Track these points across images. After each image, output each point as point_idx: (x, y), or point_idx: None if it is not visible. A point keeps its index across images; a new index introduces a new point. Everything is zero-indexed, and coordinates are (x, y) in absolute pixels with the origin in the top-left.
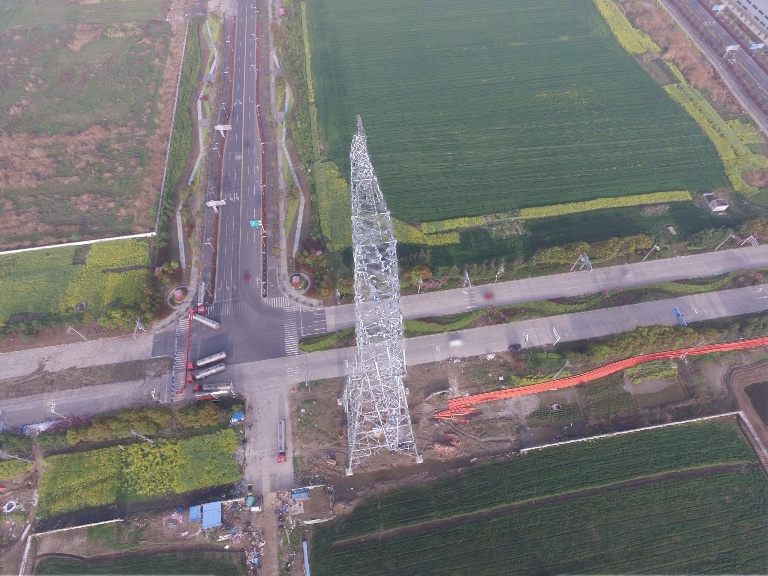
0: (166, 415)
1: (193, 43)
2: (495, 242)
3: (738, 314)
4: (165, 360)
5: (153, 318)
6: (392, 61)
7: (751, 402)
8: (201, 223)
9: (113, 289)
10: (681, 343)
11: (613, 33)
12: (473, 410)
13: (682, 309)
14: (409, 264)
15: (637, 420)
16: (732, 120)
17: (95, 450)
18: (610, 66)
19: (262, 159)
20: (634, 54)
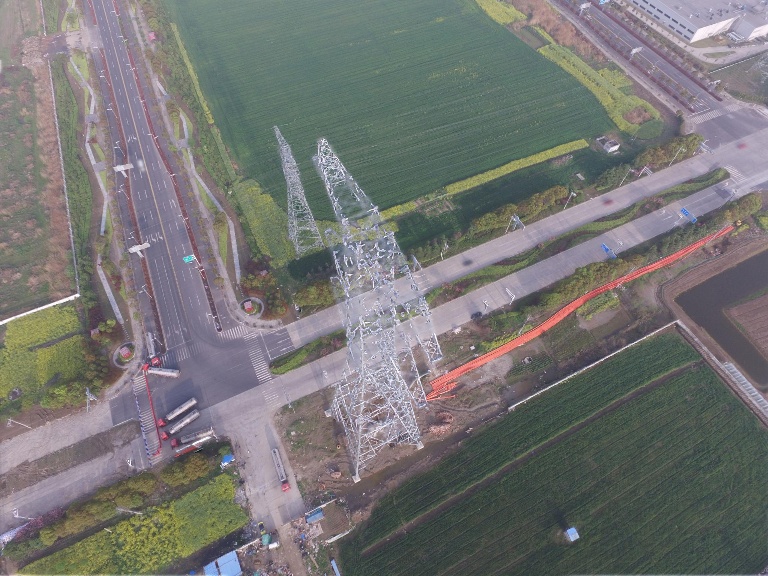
0: (150, 481)
1: (62, 85)
2: (431, 222)
3: (652, 237)
4: (130, 425)
5: (103, 384)
6: (283, 68)
7: (683, 310)
8: (128, 272)
9: (47, 366)
10: (616, 274)
11: (481, 8)
12: (456, 384)
13: (607, 244)
14: None
15: (598, 352)
16: (602, 69)
17: (78, 542)
18: (487, 39)
19: (176, 192)
20: (505, 24)
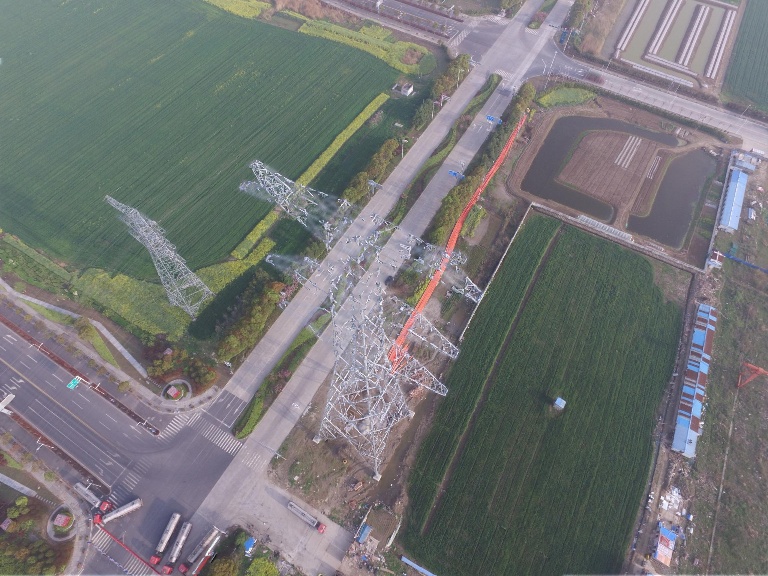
0: None
1: None
2: None
3: (478, 149)
4: None
5: (57, 570)
6: (49, 141)
7: (530, 193)
8: (6, 438)
9: None
10: (472, 190)
11: (224, 10)
12: (407, 346)
13: None
14: (255, 292)
15: (494, 257)
16: (361, 29)
17: None
18: (247, 36)
19: (5, 325)
20: (255, 18)
